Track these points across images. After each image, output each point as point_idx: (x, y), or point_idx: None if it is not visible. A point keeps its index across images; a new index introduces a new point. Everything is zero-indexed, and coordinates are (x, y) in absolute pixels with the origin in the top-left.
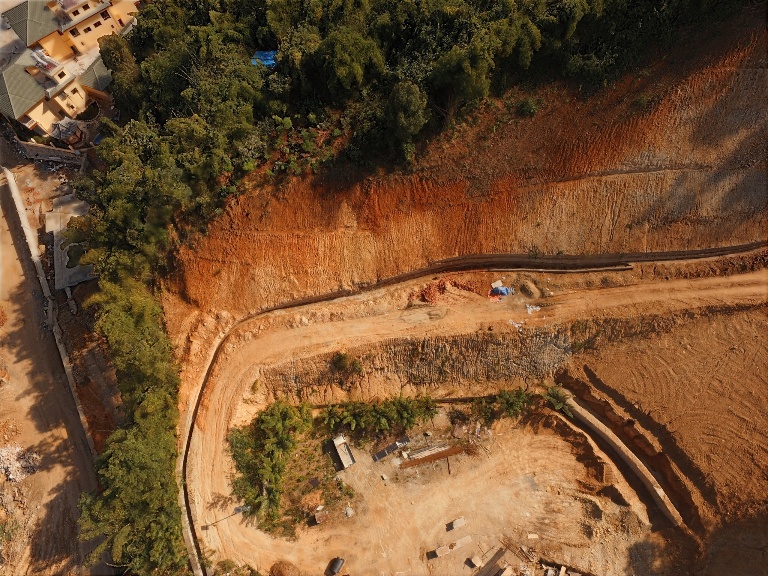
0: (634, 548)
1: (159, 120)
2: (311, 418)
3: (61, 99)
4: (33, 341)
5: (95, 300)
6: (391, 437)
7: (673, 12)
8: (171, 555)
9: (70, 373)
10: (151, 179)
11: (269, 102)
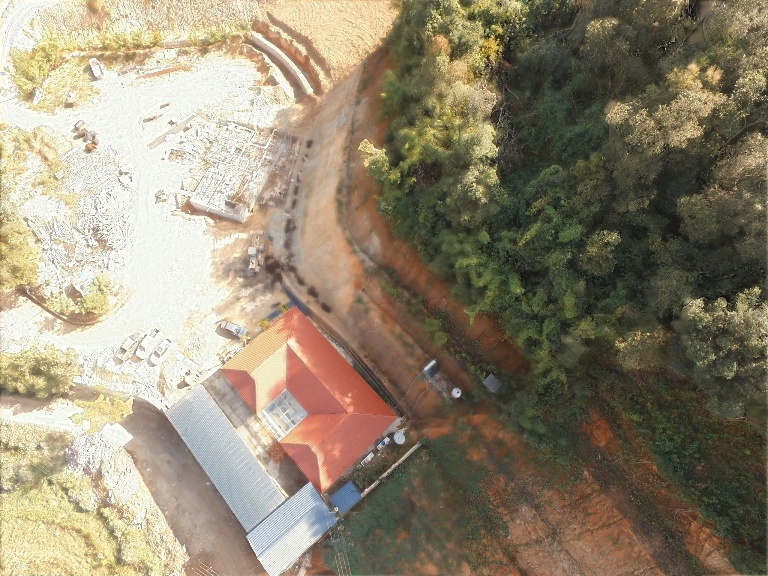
0: (281, 111)
1: None
2: (79, 56)
3: None
4: None
5: None
6: (133, 63)
7: None
8: None
9: None
10: None
11: None
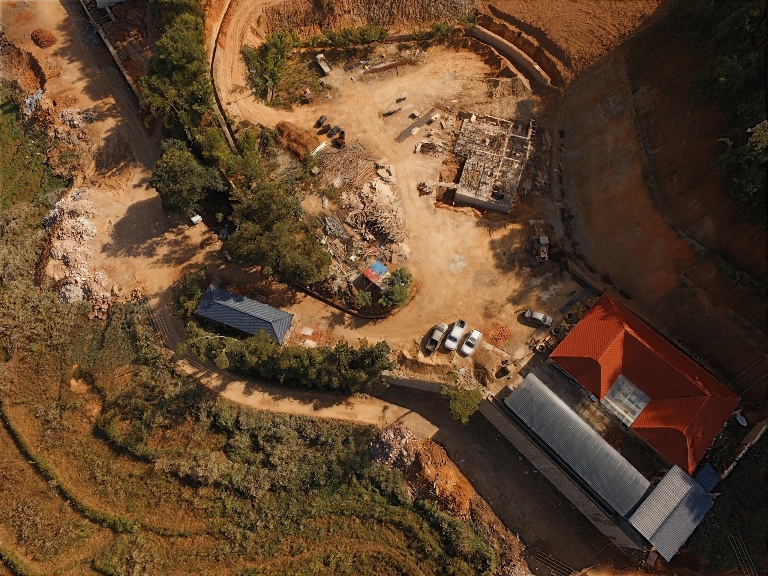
0: (521, 103)
1: None
2: (300, 52)
3: None
4: (80, 51)
5: None
6: (357, 59)
7: None
8: (207, 105)
9: (115, 54)
10: None
11: None
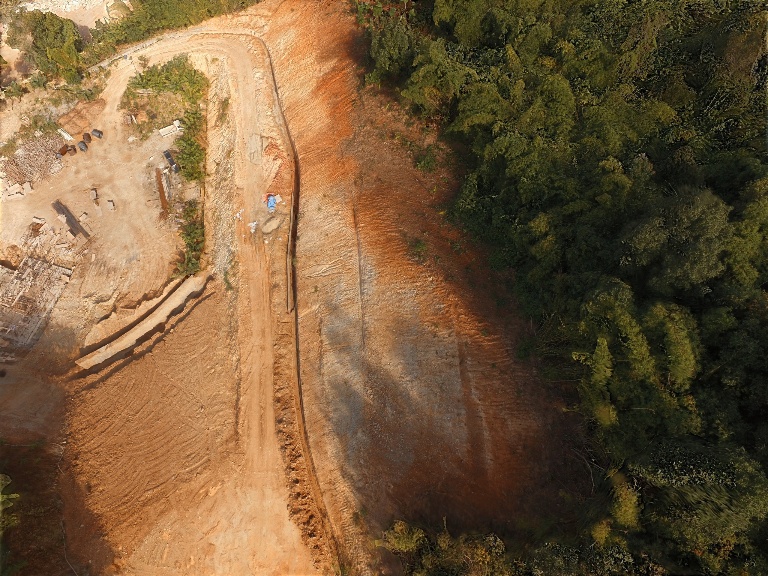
0: (71, 332)
1: None
2: None
3: None
4: None
5: None
6: None
7: (524, 248)
8: None
9: None
10: None
11: None
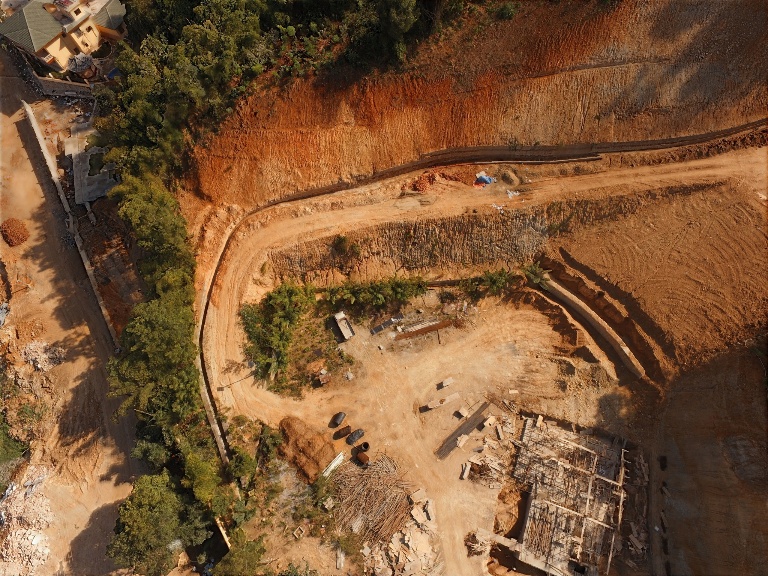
0: (603, 399)
1: (171, 43)
2: None
3: (77, 36)
4: (55, 253)
5: (119, 189)
6: (387, 315)
7: None
8: (191, 406)
9: (92, 275)
10: (169, 78)
11: (274, 13)
